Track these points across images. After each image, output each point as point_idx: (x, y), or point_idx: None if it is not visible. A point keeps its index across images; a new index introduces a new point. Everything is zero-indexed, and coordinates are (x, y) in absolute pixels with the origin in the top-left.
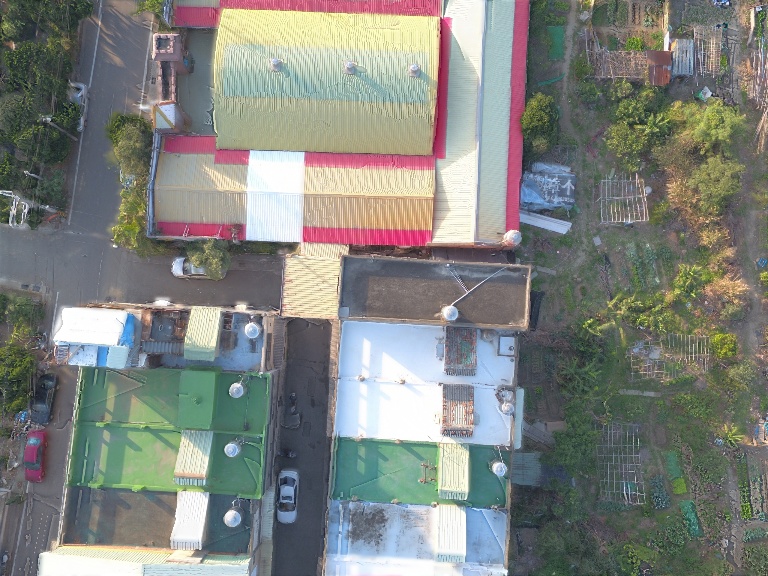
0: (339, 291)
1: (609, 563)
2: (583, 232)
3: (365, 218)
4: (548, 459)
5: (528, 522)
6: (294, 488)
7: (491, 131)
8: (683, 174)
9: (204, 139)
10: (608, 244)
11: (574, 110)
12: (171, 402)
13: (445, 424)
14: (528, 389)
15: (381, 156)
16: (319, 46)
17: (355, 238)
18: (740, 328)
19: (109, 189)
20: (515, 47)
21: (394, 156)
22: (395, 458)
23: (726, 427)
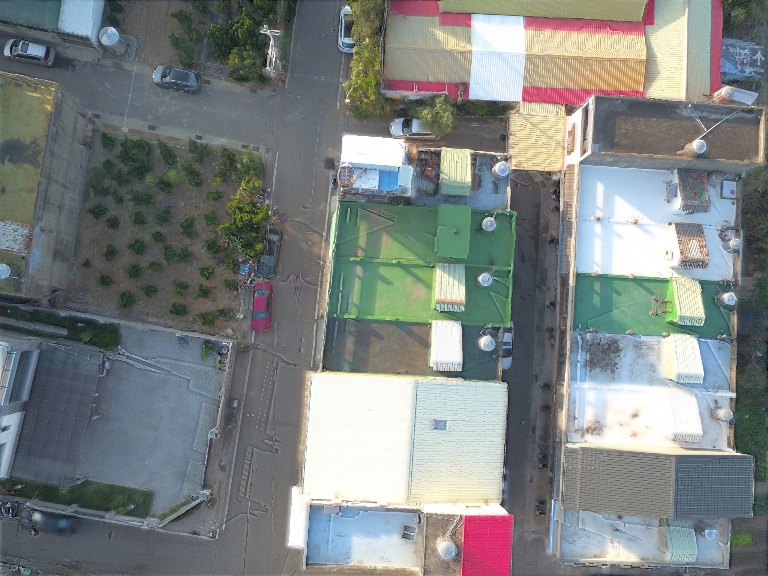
0: (592, 128)
1: None
2: (766, 103)
3: (581, 79)
4: (744, 308)
5: None
6: (512, 335)
7: None
8: None
9: (427, 3)
10: None
11: None
12: (421, 239)
13: (683, 256)
14: None
15: None
16: None
17: (571, 98)
18: None
19: (324, 55)
20: None
21: (606, 22)
22: (628, 293)
23: None
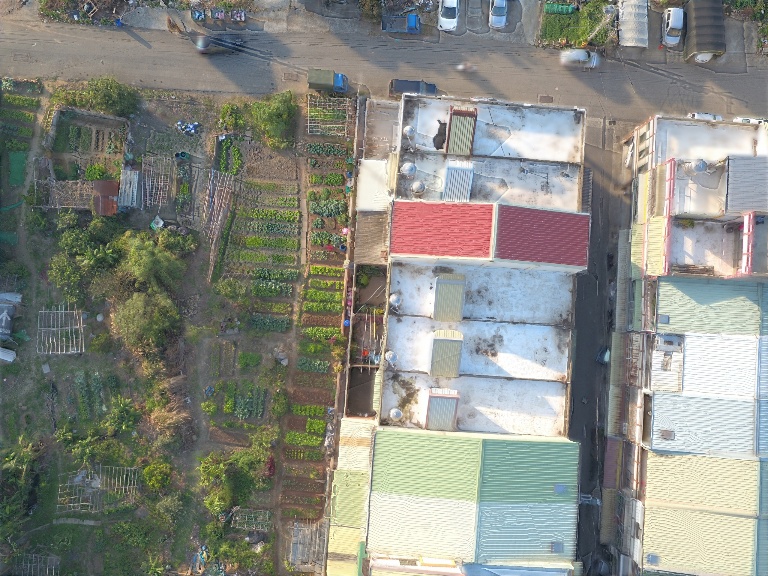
0: None
1: None
2: (33, 359)
3: None
4: None
5: None
6: None
7: None
8: None
9: None
10: (57, 372)
11: (30, 236)
12: None
13: None
14: None
15: None
16: None
17: None
18: (185, 456)
19: None
20: None
21: None
22: None
23: (150, 559)
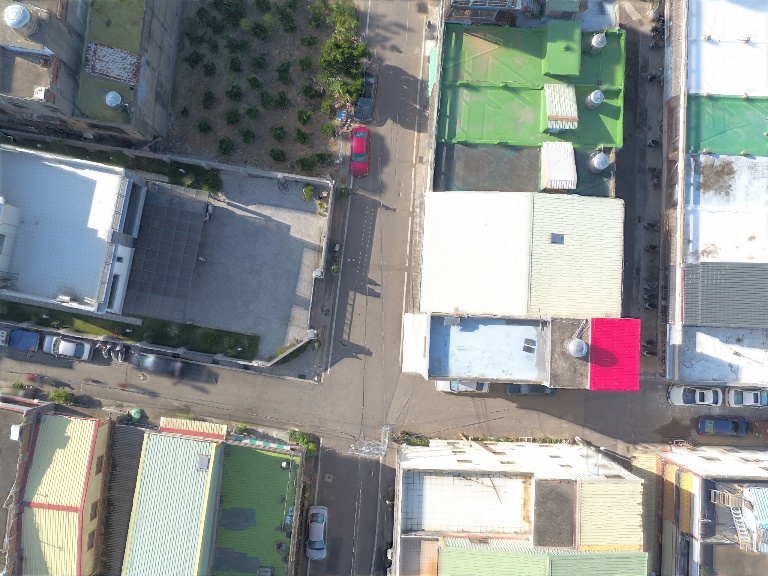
0: None
1: None
2: None
3: None
4: None
5: None
6: (615, 172)
7: None
8: None
9: None
10: None
11: None
12: (527, 62)
13: None
14: None
15: None
16: None
17: None
18: None
19: None
20: None
21: None
22: (741, 113)
23: None
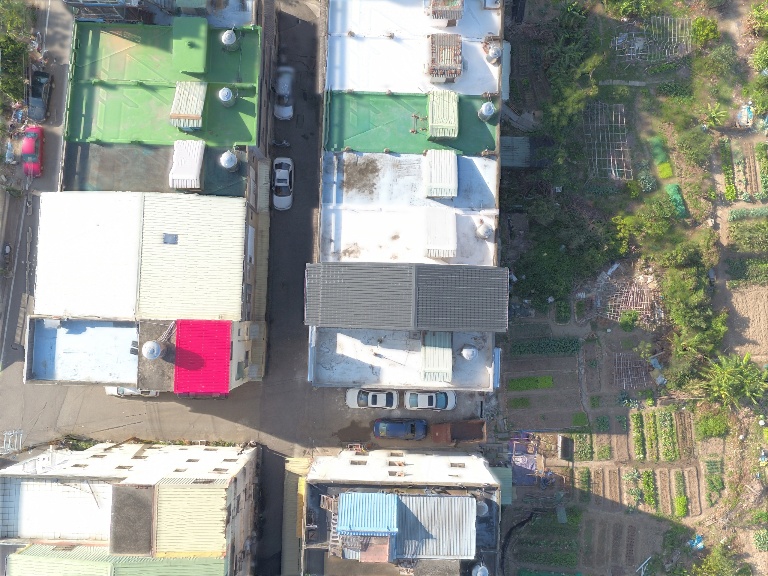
0: None
1: (598, 235)
2: None
3: None
4: (537, 140)
5: (519, 206)
6: (289, 172)
7: None
8: None
9: None
10: None
11: None
12: (165, 60)
13: (434, 63)
14: (516, 81)
15: None
16: None
17: None
18: (722, 19)
19: None
20: None
21: None
22: (386, 110)
23: (709, 106)
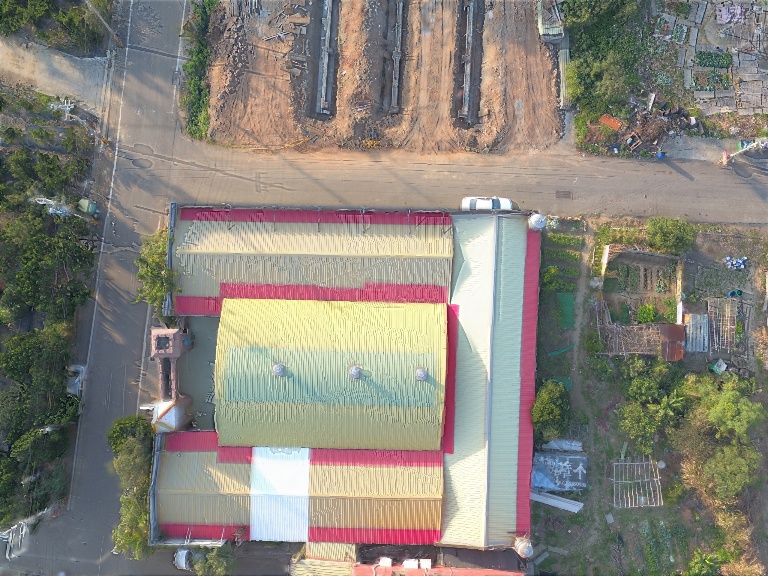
0: None
1: None
2: (595, 509)
3: (371, 519)
4: None
5: None
6: None
7: (500, 427)
8: (698, 456)
9: (205, 435)
10: (621, 522)
11: (585, 381)
12: None
13: None
14: None
15: (387, 452)
16: (322, 342)
17: (361, 538)
18: None
19: (108, 472)
20: (524, 334)
21: (401, 452)
22: None
23: None
